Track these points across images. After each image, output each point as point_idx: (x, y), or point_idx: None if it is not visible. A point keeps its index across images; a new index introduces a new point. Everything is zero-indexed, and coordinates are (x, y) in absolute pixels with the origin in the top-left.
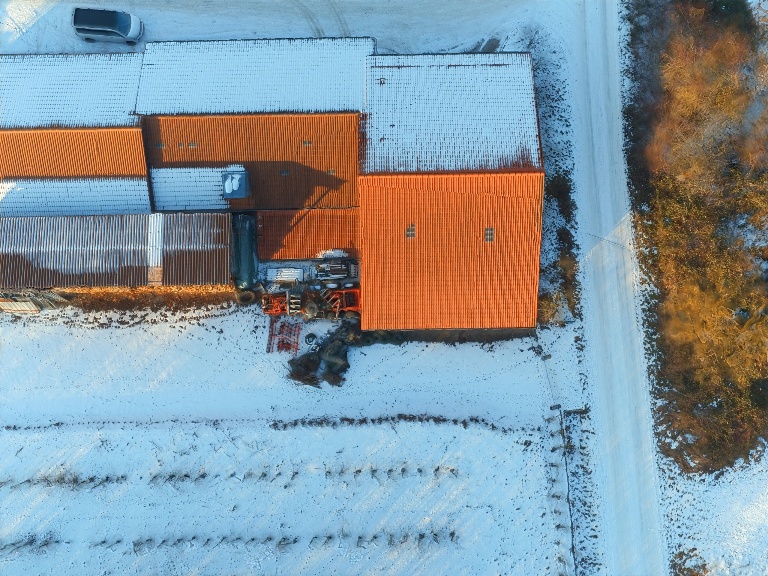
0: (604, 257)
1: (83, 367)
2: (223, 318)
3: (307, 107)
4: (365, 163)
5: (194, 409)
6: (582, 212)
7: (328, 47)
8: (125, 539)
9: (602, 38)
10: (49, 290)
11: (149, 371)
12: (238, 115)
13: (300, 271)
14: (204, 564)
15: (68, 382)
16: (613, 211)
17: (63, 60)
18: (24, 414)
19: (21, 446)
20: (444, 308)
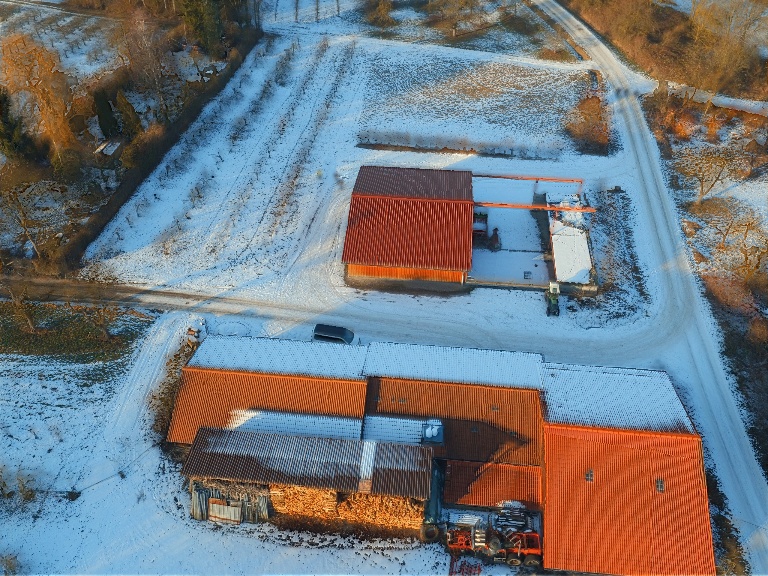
0: (764, 542)
1: None
2: (406, 551)
3: (496, 384)
4: (548, 419)
5: None
6: (732, 502)
7: (507, 355)
8: None
9: (714, 384)
10: (264, 494)
11: None
12: (442, 383)
13: (480, 518)
14: None
15: None
16: (761, 505)
17: (309, 344)
18: None
19: None
20: (624, 554)
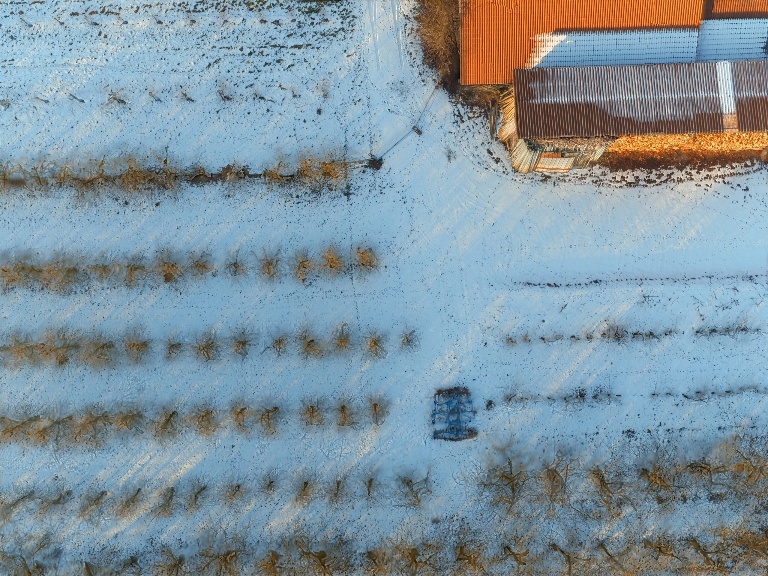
0: None
1: (615, 225)
2: (748, 176)
3: None
4: None
5: (724, 266)
6: None
7: None
8: (674, 392)
9: None
10: (608, 142)
11: (679, 229)
12: None
13: None
14: (757, 414)
15: (601, 240)
16: None
17: None
18: (560, 272)
19: (565, 302)
20: None
